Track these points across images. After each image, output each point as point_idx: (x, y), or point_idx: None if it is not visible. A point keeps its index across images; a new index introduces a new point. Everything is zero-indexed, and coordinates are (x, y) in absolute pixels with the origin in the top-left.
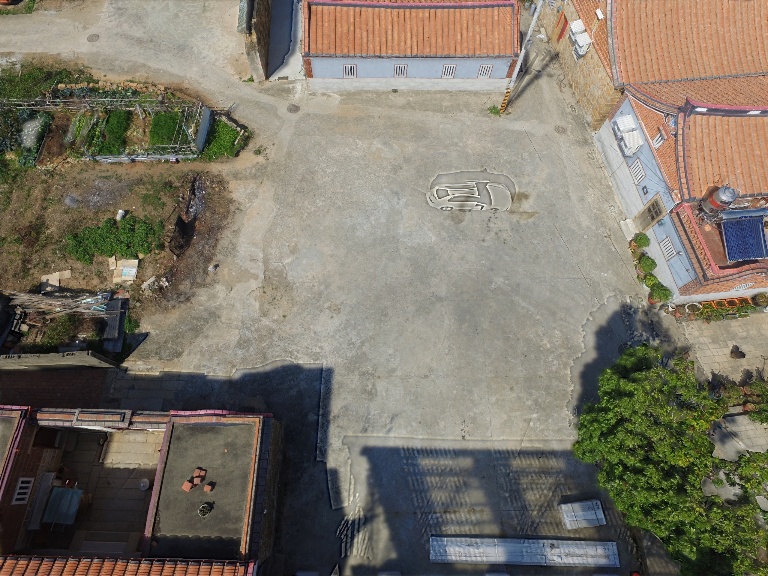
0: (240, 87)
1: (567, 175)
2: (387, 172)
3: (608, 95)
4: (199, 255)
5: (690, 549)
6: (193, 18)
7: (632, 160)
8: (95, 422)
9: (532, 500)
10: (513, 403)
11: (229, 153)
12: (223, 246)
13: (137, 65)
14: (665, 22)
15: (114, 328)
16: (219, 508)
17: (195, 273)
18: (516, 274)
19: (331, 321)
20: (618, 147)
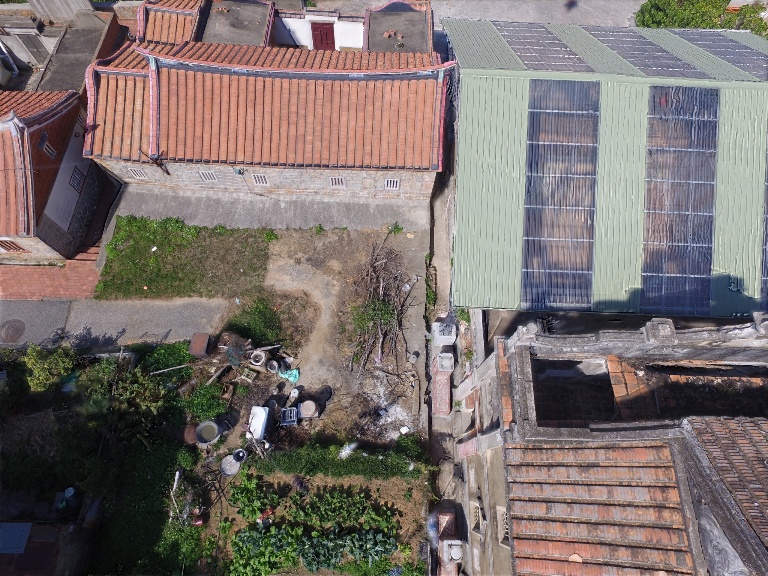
0: None
1: None
2: None
3: None
4: None
5: None
6: None
7: None
8: (318, 12)
9: None
10: None
11: None
12: None
13: None
14: None
15: None
16: (408, 46)
17: None
18: None
19: (449, 10)
20: None
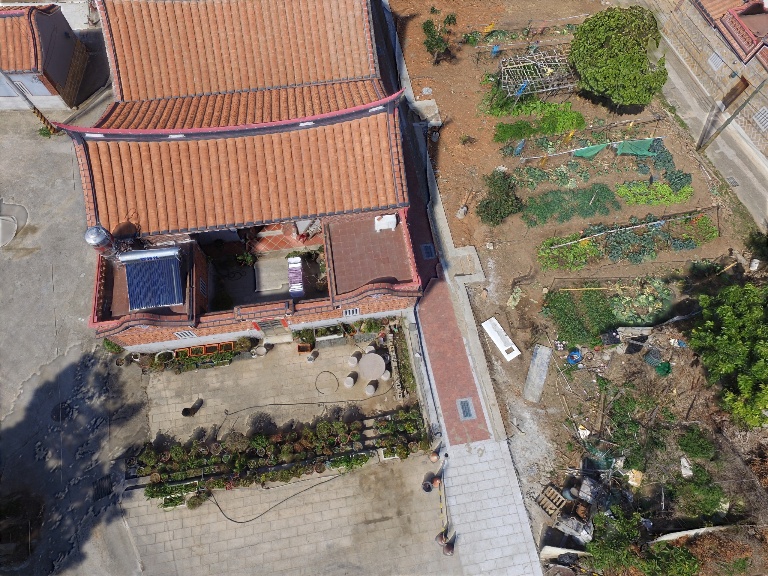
0: None
1: None
2: None
3: None
4: None
5: None
6: None
7: None
8: None
9: None
10: None
11: None
12: None
13: None
14: (176, 31)
15: None
16: None
17: None
18: None
19: None
20: None
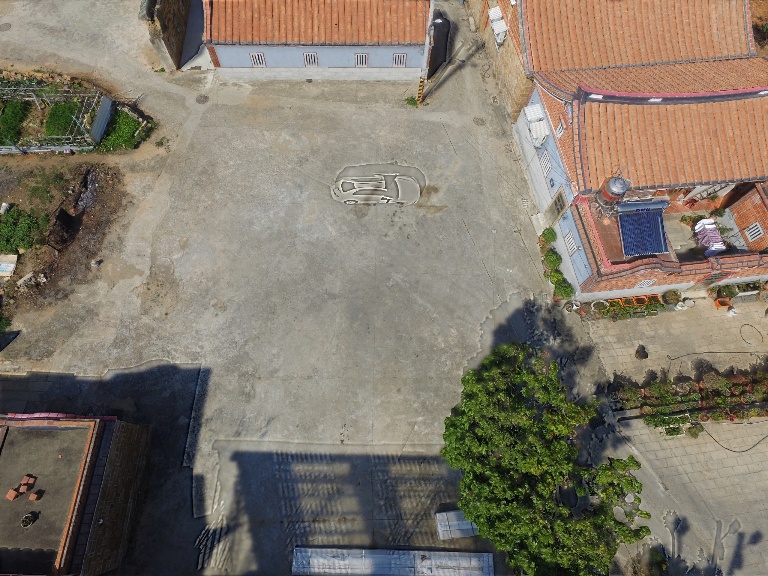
0: (151, 77)
1: (481, 168)
2: (292, 164)
3: (522, 84)
4: (83, 250)
5: (528, 565)
6: (110, 7)
7: (541, 151)
8: None
9: (408, 508)
10: (399, 405)
11: (127, 144)
12: (110, 241)
13: (47, 55)
14: (579, 8)
15: None
16: (44, 518)
17: (77, 269)
18: (416, 270)
19: (215, 319)
20: None
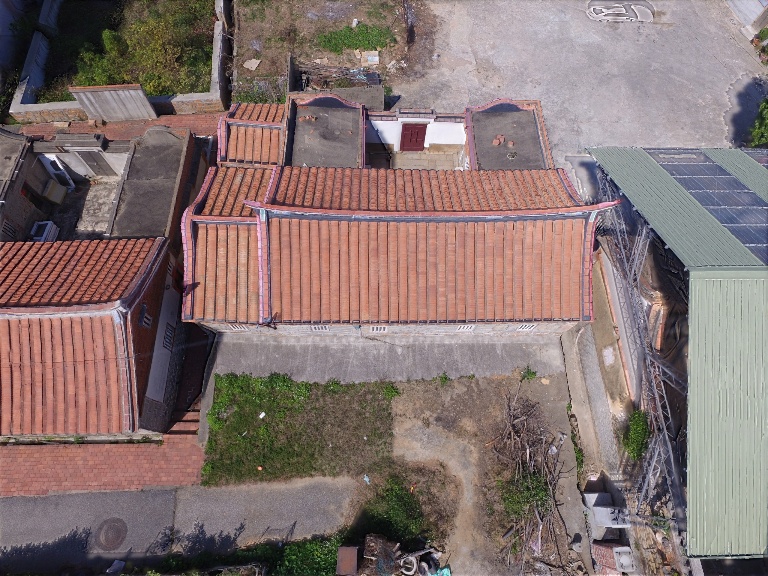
0: None
1: (692, 0)
2: None
3: None
4: (423, 48)
5: None
6: None
7: None
8: (413, 114)
9: None
10: (686, 137)
11: None
12: (439, 44)
13: None
14: None
15: None
16: (521, 155)
17: (423, 60)
18: (668, 61)
19: (535, 89)
20: None
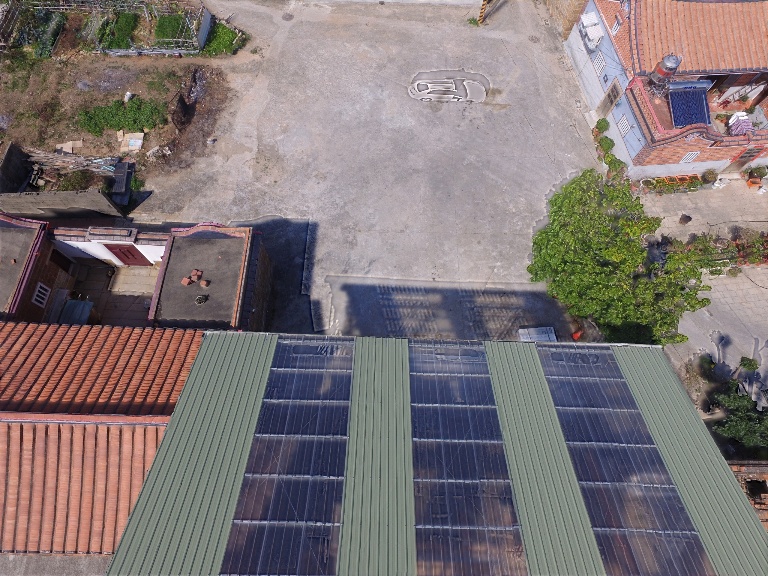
0: (239, 0)
1: (538, 76)
2: (372, 69)
3: (576, 0)
4: (199, 131)
5: (616, 315)
6: None
7: (595, 54)
8: (105, 236)
9: (493, 329)
10: (480, 253)
11: (228, 50)
12: (221, 125)
13: None
14: None
15: (122, 184)
16: (213, 299)
17: (195, 145)
18: (487, 153)
19: (317, 186)
20: (584, 46)
